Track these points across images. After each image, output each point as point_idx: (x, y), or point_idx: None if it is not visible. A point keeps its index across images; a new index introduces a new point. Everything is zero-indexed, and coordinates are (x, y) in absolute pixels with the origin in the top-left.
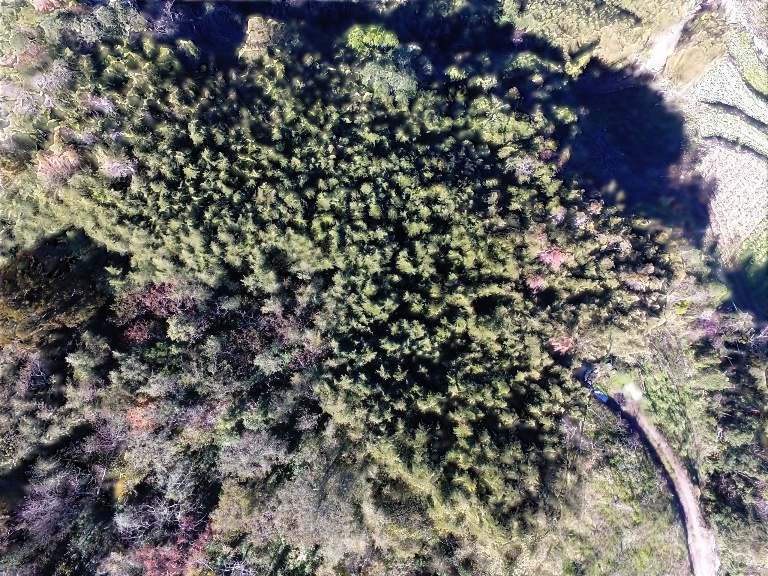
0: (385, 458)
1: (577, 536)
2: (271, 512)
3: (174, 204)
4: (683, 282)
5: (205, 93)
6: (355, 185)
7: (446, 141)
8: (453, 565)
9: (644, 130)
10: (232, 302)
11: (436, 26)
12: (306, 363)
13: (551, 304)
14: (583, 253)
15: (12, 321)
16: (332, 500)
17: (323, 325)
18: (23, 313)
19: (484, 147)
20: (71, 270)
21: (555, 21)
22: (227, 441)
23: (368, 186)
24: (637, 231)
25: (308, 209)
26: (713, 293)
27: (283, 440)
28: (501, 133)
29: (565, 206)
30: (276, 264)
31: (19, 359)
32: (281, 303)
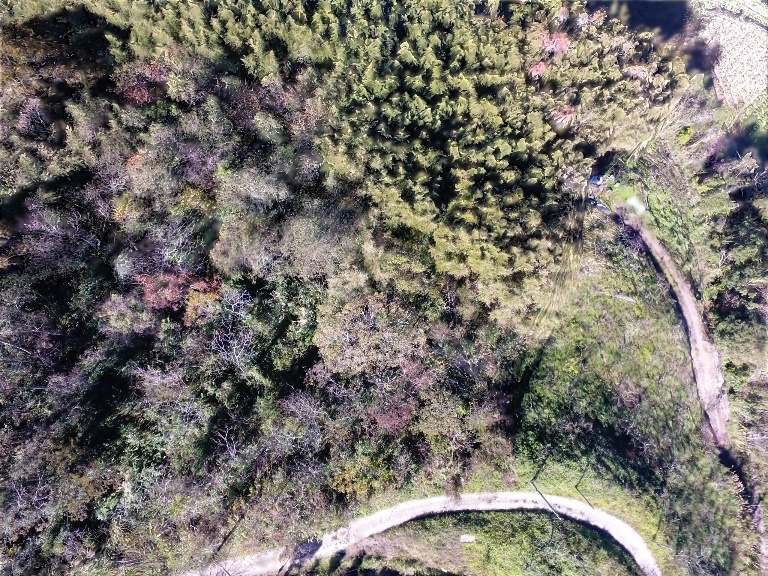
0: (386, 200)
1: (580, 324)
2: (272, 247)
3: None
4: (686, 110)
5: None
6: None
7: None
8: (455, 337)
9: (647, 6)
10: (232, 79)
11: None
12: (307, 127)
13: None
14: (586, 52)
15: (11, 63)
16: (333, 234)
17: (324, 92)
18: (22, 56)
19: None
20: (71, 44)
21: None
22: (228, 182)
23: None
24: None
25: (308, 10)
26: (717, 116)
27: (284, 184)
28: None
29: None
30: None
31: (19, 106)
32: (281, 78)
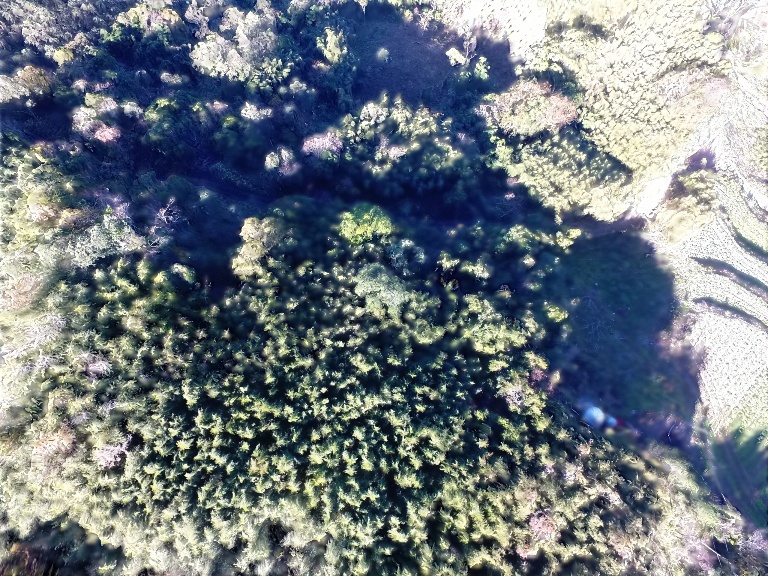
0: None
1: None
2: None
3: (168, 487)
4: None
5: (199, 338)
6: (347, 429)
7: (438, 357)
8: None
9: (635, 287)
10: None
11: (429, 178)
12: None
13: (540, 572)
14: (572, 507)
15: None
16: None
17: None
18: None
19: (475, 360)
20: (65, 563)
21: (547, 177)
22: None
23: (360, 434)
24: (626, 469)
25: (301, 464)
26: (701, 516)
27: None
28: (492, 346)
29: (555, 451)
30: (269, 528)
31: None
32: None
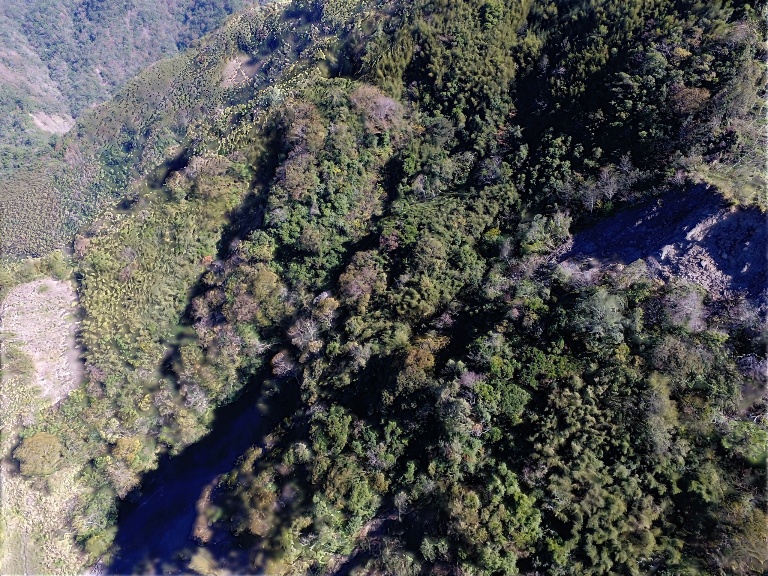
0: None
1: None
2: None
3: None
4: None
5: None
6: None
7: None
8: None
9: None
10: None
11: None
12: None
13: None
14: None
15: None
16: None
17: None
18: None
19: None
20: None
21: None
22: None
23: None
24: None
25: None
26: None
27: None
28: None
29: None
30: None
31: None
32: None
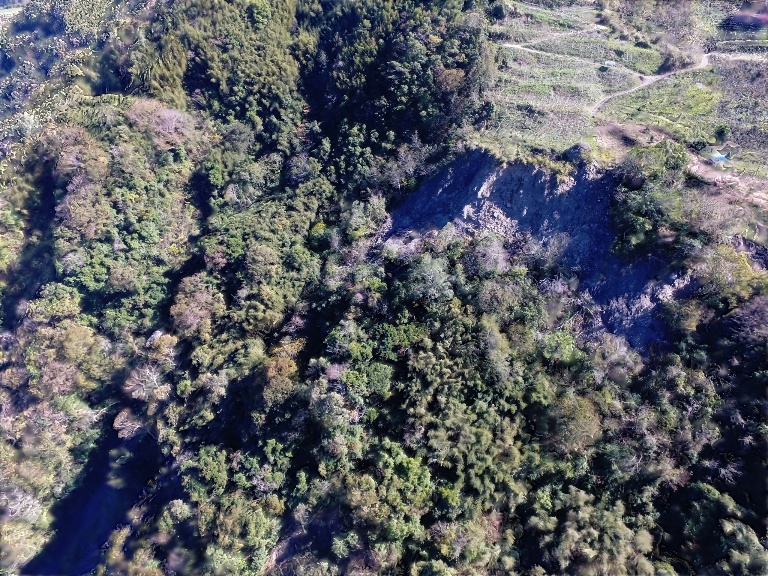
0: None
1: None
2: None
3: None
4: None
5: None
6: None
7: (40, 1)
8: None
9: None
10: None
11: None
12: None
13: None
14: None
15: None
16: None
17: None
18: None
19: None
20: None
21: (1, 32)
22: None
23: None
24: None
25: None
26: None
27: None
28: (33, 1)
29: None
30: None
31: None
32: None
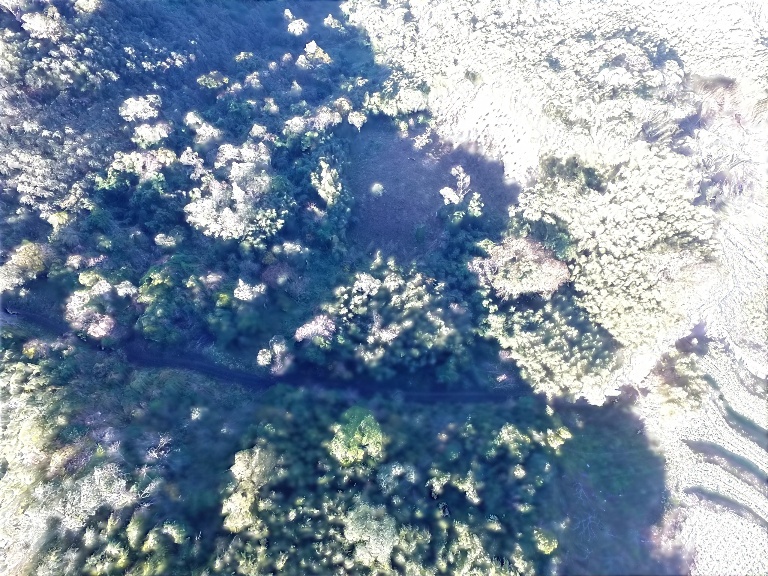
0: None
1: None
2: None
3: None
4: None
5: None
6: None
7: None
8: None
9: (626, 471)
10: None
11: (421, 355)
12: None
13: None
14: None
15: None
16: None
17: None
18: None
19: None
20: None
21: (538, 359)
22: None
23: None
24: None
25: None
26: None
27: None
28: None
29: None
30: None
31: None
32: None
